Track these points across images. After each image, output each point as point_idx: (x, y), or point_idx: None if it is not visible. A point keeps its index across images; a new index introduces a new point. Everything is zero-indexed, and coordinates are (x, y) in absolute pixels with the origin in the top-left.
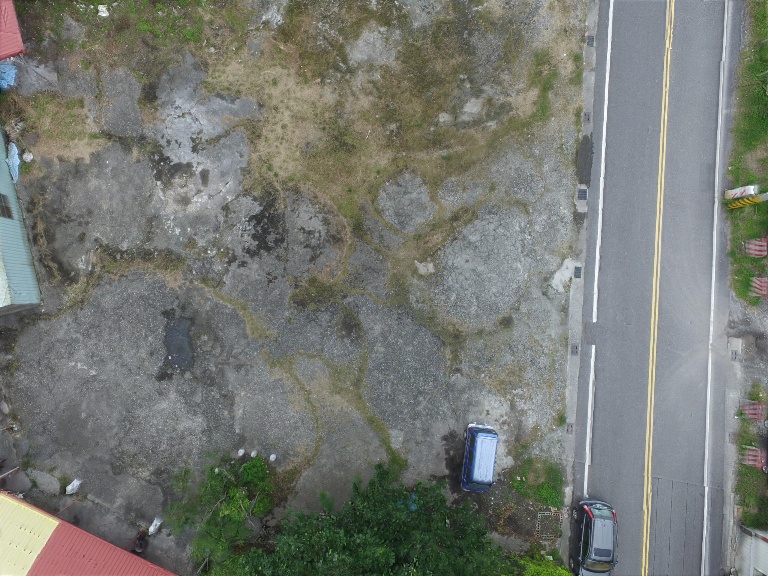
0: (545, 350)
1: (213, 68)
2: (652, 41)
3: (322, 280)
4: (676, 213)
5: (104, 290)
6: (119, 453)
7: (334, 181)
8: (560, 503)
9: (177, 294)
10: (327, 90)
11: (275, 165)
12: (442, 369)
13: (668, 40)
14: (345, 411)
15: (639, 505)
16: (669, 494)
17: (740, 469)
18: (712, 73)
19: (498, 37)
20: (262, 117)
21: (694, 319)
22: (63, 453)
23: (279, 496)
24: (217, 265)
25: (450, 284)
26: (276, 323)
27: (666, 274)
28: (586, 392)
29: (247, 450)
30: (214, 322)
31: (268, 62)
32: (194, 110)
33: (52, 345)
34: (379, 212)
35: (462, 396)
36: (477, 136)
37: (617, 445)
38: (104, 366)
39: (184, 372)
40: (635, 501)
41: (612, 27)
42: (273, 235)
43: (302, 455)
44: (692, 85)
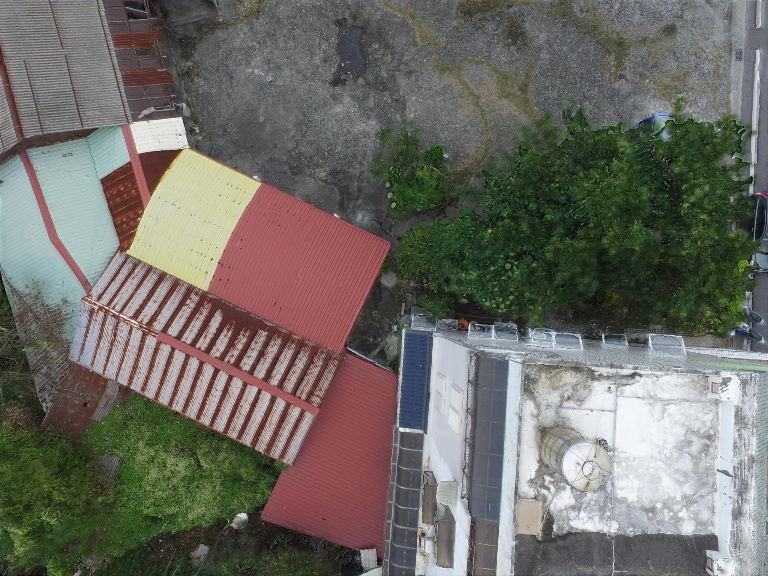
0: (709, 56)
1: None
2: None
3: None
4: None
5: (278, 1)
6: (296, 155)
7: None
8: None
9: (348, 4)
10: None
11: None
12: (607, 75)
13: None
14: (514, 114)
15: None
16: None
17: None
18: None
19: None
20: None
21: None
22: (243, 155)
23: (451, 196)
24: None
25: None
26: (444, 31)
27: None
28: (750, 96)
29: None
30: (384, 31)
31: None
32: None
33: (230, 53)
34: None
35: (628, 100)
36: None
37: None
38: (280, 72)
39: (357, 78)
40: None
41: None
42: None
43: (472, 157)
44: None
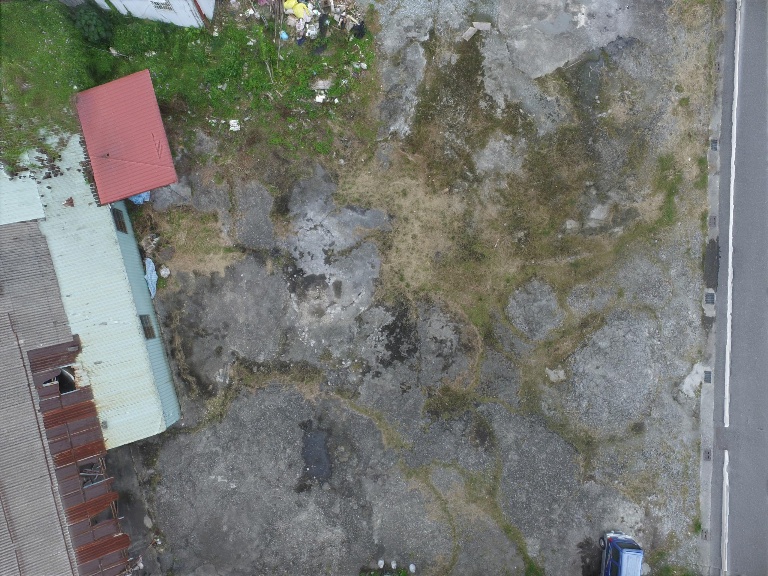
0: (677, 455)
1: (343, 180)
2: None
3: (455, 389)
4: None
5: (242, 403)
6: (261, 565)
7: (464, 290)
8: None
9: (313, 405)
10: (455, 199)
11: (406, 275)
12: (576, 476)
13: None
14: (482, 520)
15: None
16: None
17: None
18: None
19: (623, 143)
20: (392, 228)
21: None
22: (206, 566)
23: None
24: (352, 376)
25: (581, 391)
26: (411, 433)
27: None
28: (720, 497)
29: (386, 560)
30: (350, 433)
31: (397, 173)
32: (325, 222)
33: (192, 459)
34: (510, 320)
35: (597, 503)
36: (604, 242)
37: (752, 550)
38: (244, 479)
39: (322, 483)
40: None
41: (736, 131)
42: (406, 345)
43: (440, 564)
44: None
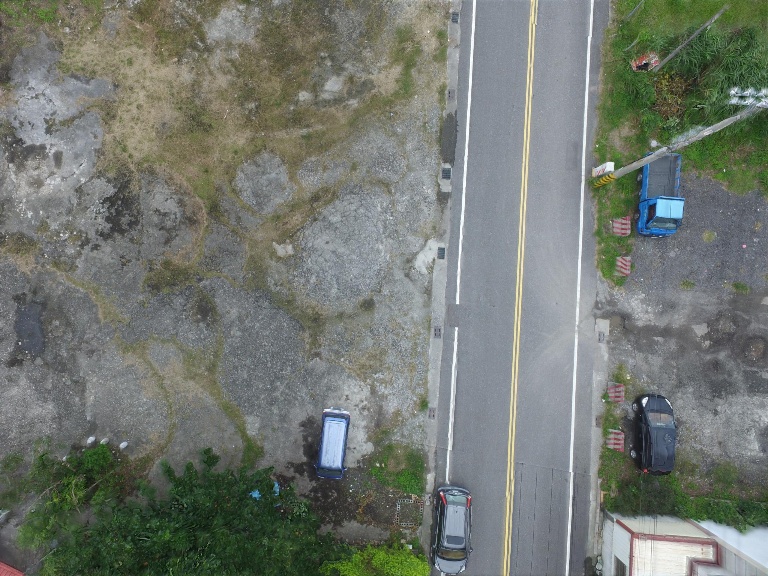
0: (407, 333)
1: (67, 48)
2: (517, 17)
3: (178, 263)
4: (541, 192)
5: None
6: None
7: (191, 162)
8: (420, 490)
9: (28, 278)
10: (184, 69)
11: (130, 146)
12: (300, 353)
13: (533, 15)
14: (200, 397)
15: (502, 492)
16: (533, 480)
17: (607, 454)
18: (579, 49)
19: (360, 14)
20: (117, 97)
21: (560, 300)
22: None
23: (131, 485)
24: (70, 248)
25: (309, 266)
26: (130, 307)
27: (531, 254)
28: (449, 376)
29: (98, 438)
30: (66, 307)
31: (124, 41)
32: (48, 91)
33: None
34: (237, 193)
35: (321, 381)
36: (338, 115)
37: (480, 430)
38: None
39: (34, 358)
40: (498, 487)
41: (476, 3)
42: (128, 217)
43: (155, 442)
44: (558, 61)
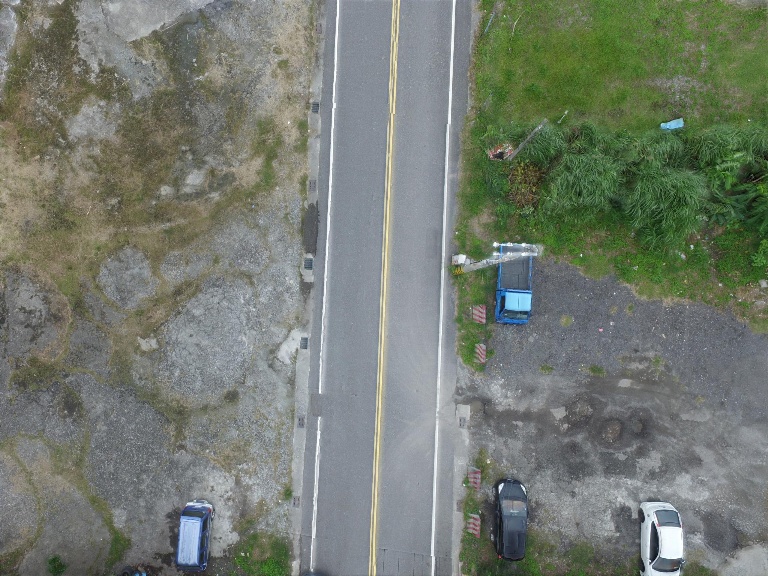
0: (271, 423)
1: None
2: (376, 106)
3: (44, 360)
4: (401, 280)
5: None
6: None
7: (55, 259)
8: None
9: None
10: (47, 167)
11: None
12: (166, 446)
13: (390, 105)
14: (67, 492)
15: None
16: (395, 565)
17: (467, 538)
18: (438, 136)
19: (220, 107)
20: None
21: (421, 387)
22: None
23: None
24: None
25: (174, 359)
26: None
27: (392, 343)
28: (312, 464)
29: None
30: None
31: None
32: None
33: None
34: (101, 289)
35: (186, 473)
36: (200, 208)
37: (343, 517)
38: None
39: None
40: (361, 573)
41: (335, 93)
42: None
43: (24, 537)
44: (417, 149)
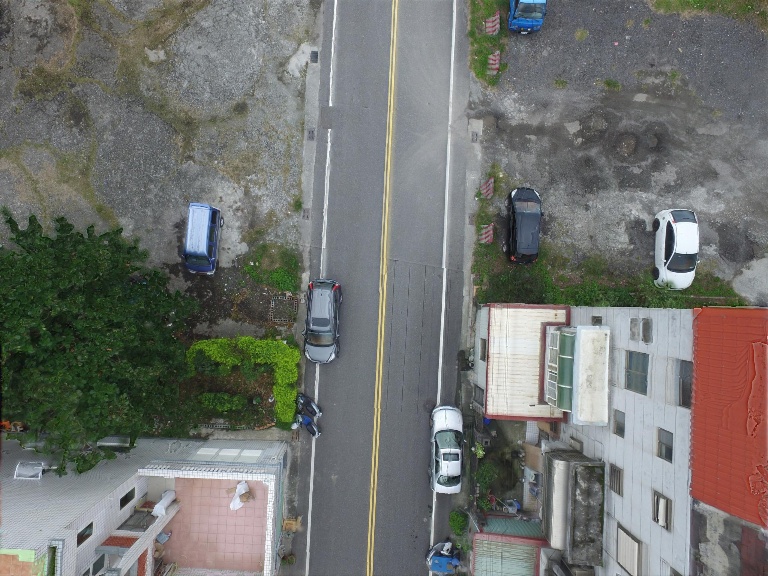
0: (280, 136)
1: None
2: None
3: (49, 69)
4: None
5: None
6: None
7: None
8: (293, 287)
9: None
10: None
11: None
12: (174, 156)
13: None
14: (73, 200)
15: (375, 287)
16: (406, 276)
17: (479, 249)
18: None
19: None
20: None
21: (433, 100)
22: None
23: None
24: None
25: (182, 71)
26: (2, 113)
27: (403, 55)
28: (322, 177)
29: None
30: None
31: None
32: None
33: None
34: None
35: (194, 183)
36: None
37: (353, 229)
38: None
39: None
40: (371, 284)
41: None
42: None
43: None
44: None
